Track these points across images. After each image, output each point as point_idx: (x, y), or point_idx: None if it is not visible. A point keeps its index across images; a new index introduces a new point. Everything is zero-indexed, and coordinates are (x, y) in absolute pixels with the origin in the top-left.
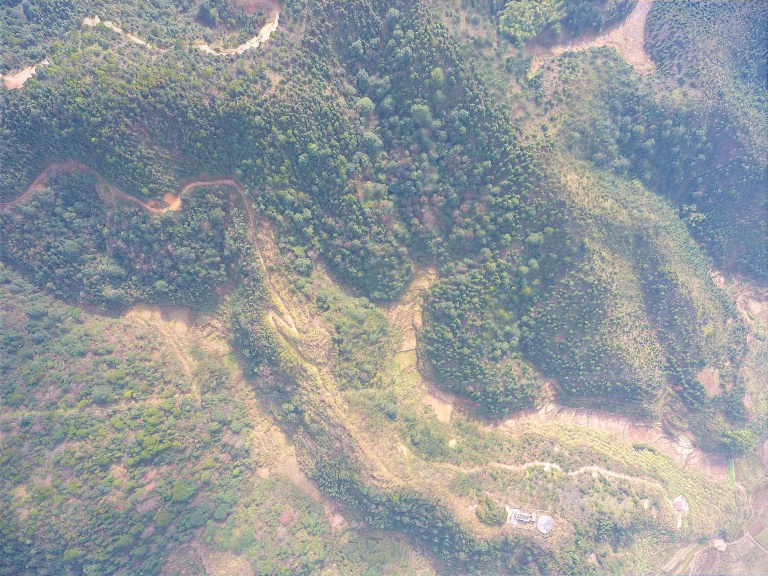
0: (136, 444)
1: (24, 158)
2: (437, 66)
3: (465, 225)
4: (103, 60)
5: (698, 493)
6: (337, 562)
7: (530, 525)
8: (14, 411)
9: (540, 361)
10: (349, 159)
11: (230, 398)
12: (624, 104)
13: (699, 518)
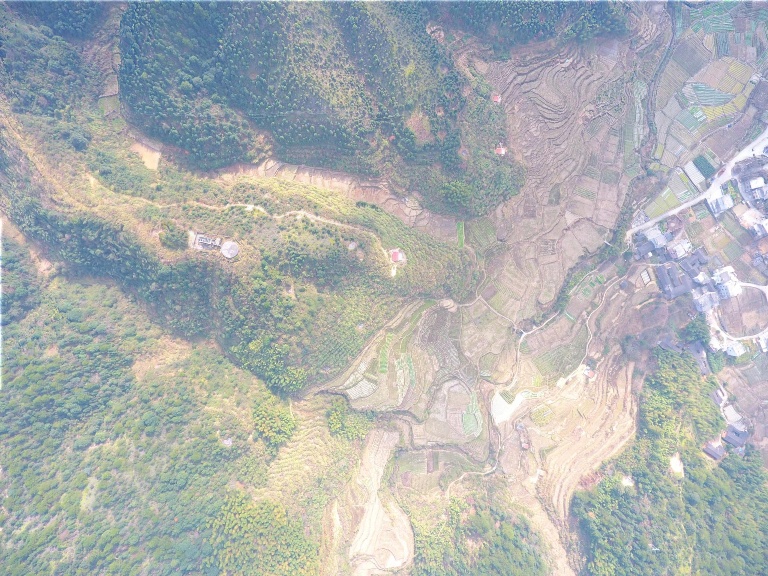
0: None
1: None
2: None
3: None
4: None
5: (421, 249)
6: (42, 304)
7: (216, 251)
8: None
9: (247, 107)
10: None
11: None
12: None
13: (417, 270)
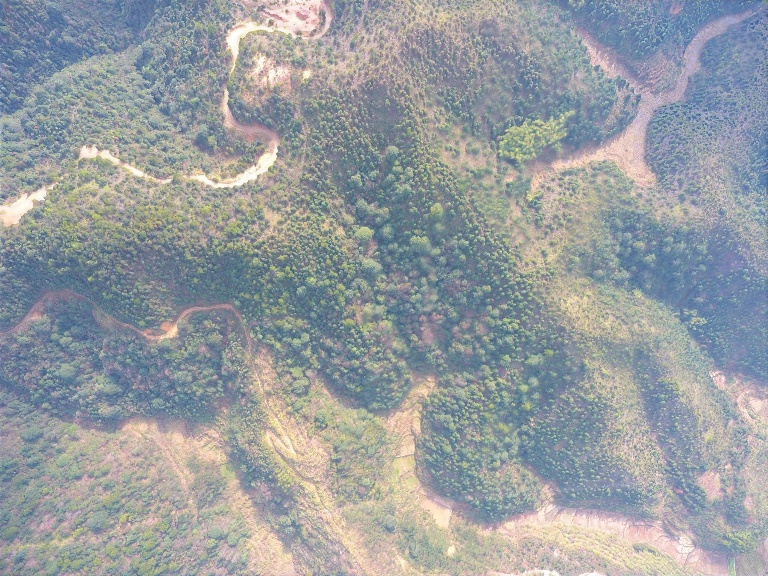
0: (131, 571)
1: (20, 292)
2: (436, 201)
3: (464, 341)
4: (100, 201)
5: None
6: None
7: None
8: (8, 545)
9: (540, 466)
10: (348, 286)
11: (227, 510)
12: (625, 221)
13: None
